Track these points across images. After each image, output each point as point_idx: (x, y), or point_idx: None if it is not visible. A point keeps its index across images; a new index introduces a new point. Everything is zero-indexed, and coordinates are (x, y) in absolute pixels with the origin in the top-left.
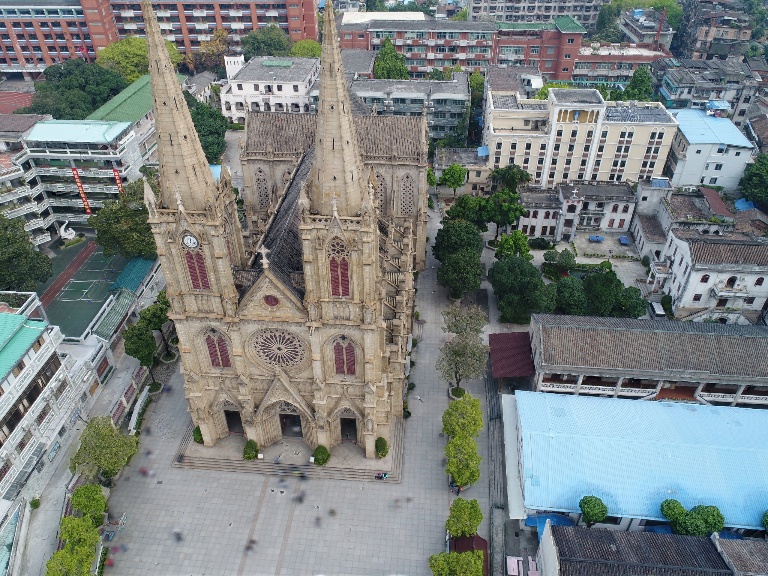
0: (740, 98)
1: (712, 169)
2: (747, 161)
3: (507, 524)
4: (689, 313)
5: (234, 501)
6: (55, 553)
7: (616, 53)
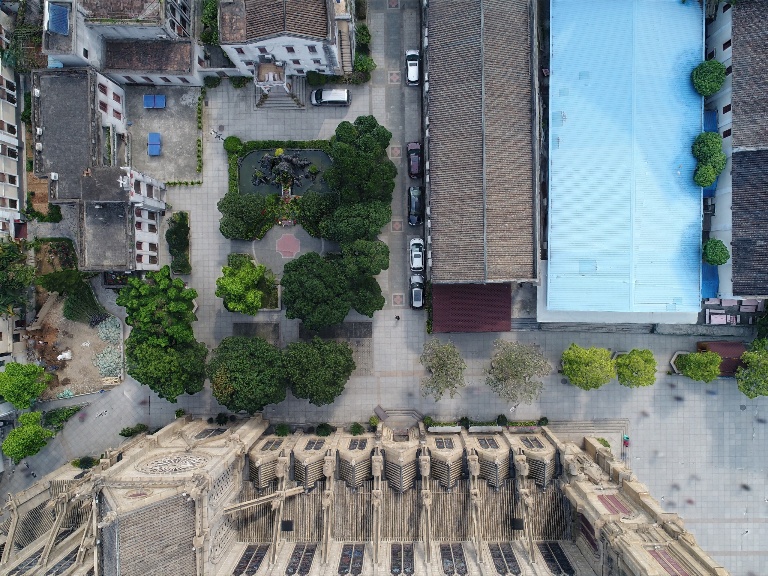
0: None
1: None
2: None
3: None
4: (340, 56)
5: None
6: None
7: None
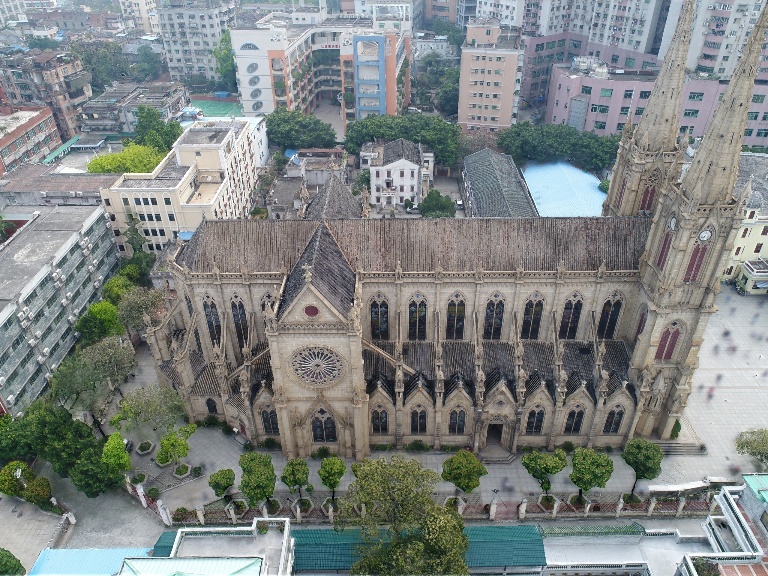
0: (188, 101)
1: (260, 146)
2: (265, 129)
3: None
4: (422, 198)
5: (707, 403)
6: None
7: (17, 125)
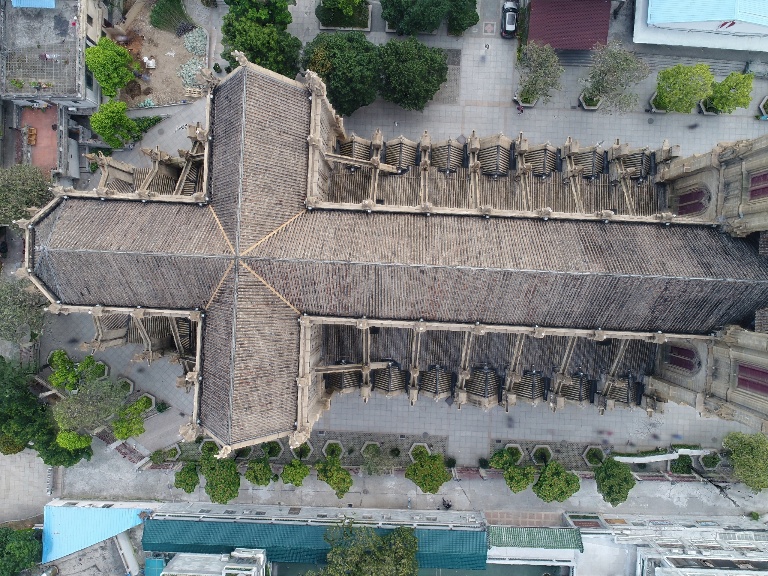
0: None
1: None
2: None
3: (765, 61)
4: None
5: None
6: None
7: None
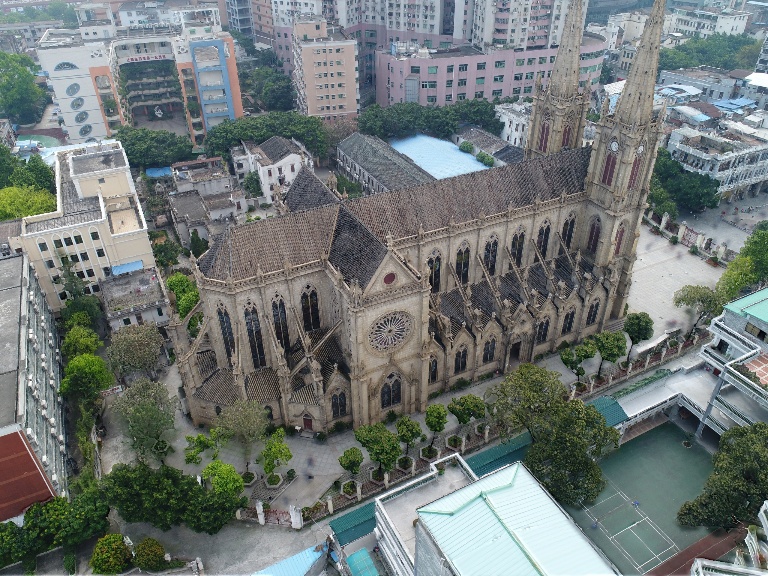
0: None
1: None
2: None
3: None
4: None
5: None
6: (745, 259)
7: None
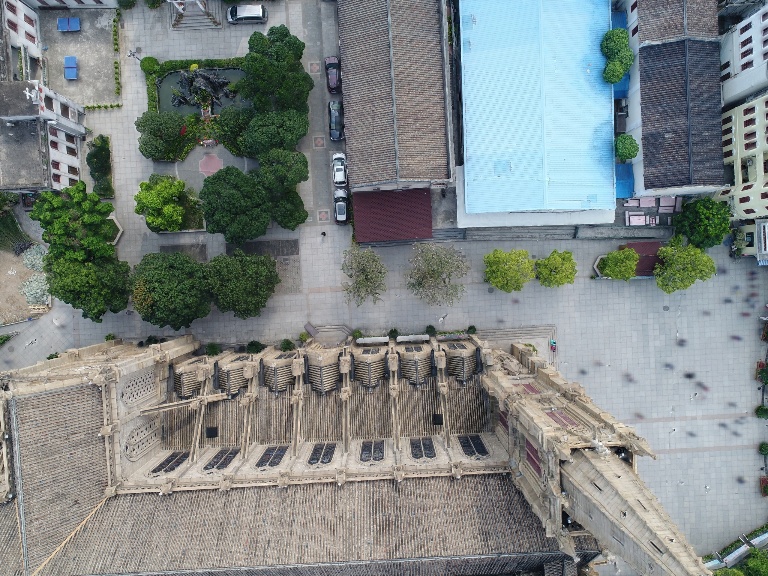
0: None
1: None
2: None
3: (592, 224)
4: None
5: None
6: None
7: None
